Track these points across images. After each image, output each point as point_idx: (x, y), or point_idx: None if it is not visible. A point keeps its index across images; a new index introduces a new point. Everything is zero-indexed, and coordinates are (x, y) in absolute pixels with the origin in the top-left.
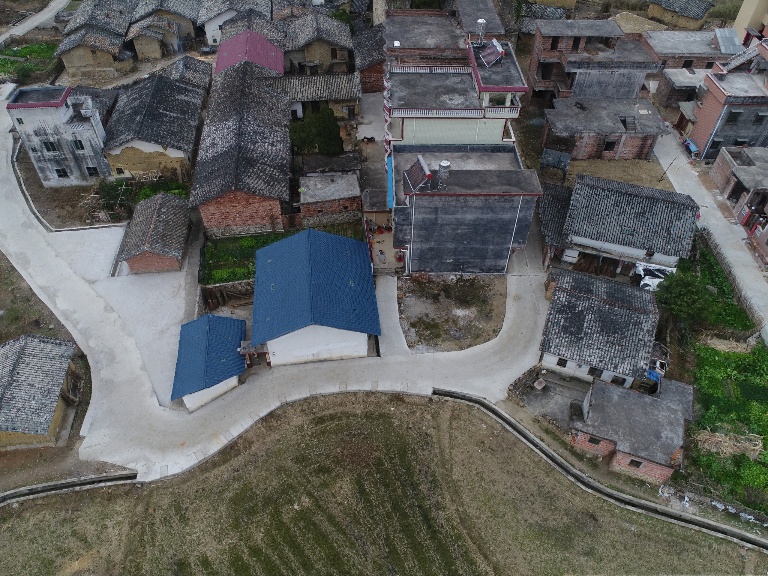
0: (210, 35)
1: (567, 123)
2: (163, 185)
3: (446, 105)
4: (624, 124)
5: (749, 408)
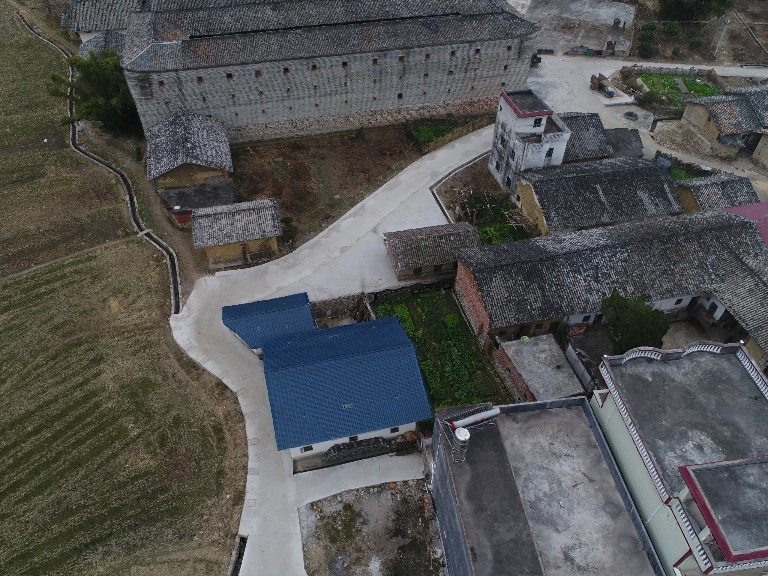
0: None
1: None
2: (521, 235)
3: (675, 440)
4: None
5: None
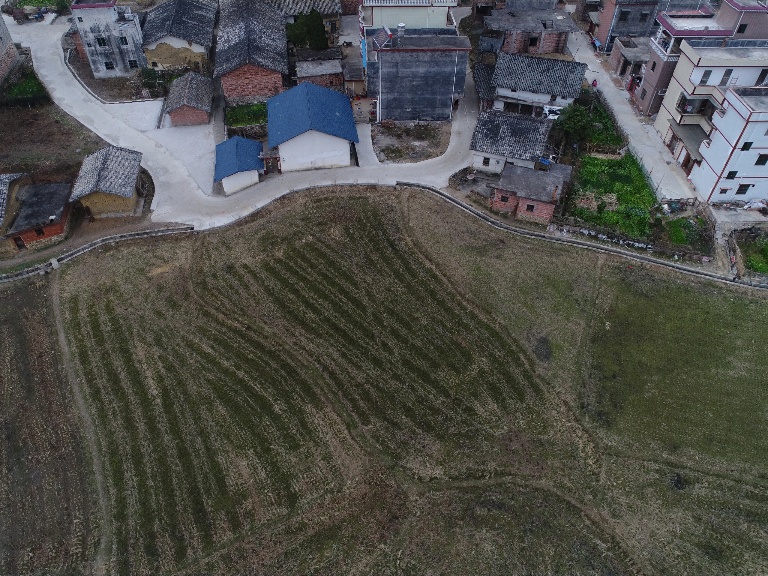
0: None
1: (500, 24)
2: None
3: None
4: (545, 26)
5: (613, 185)
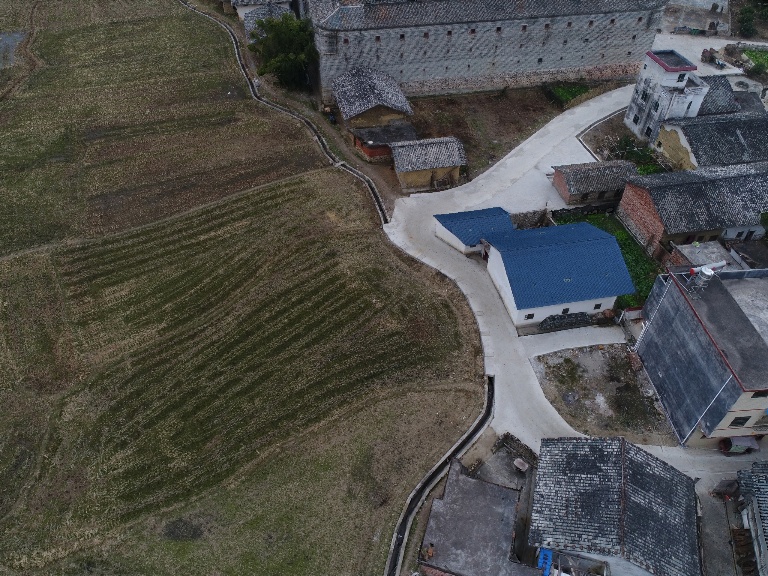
0: None
1: None
2: None
3: None
4: None
5: None
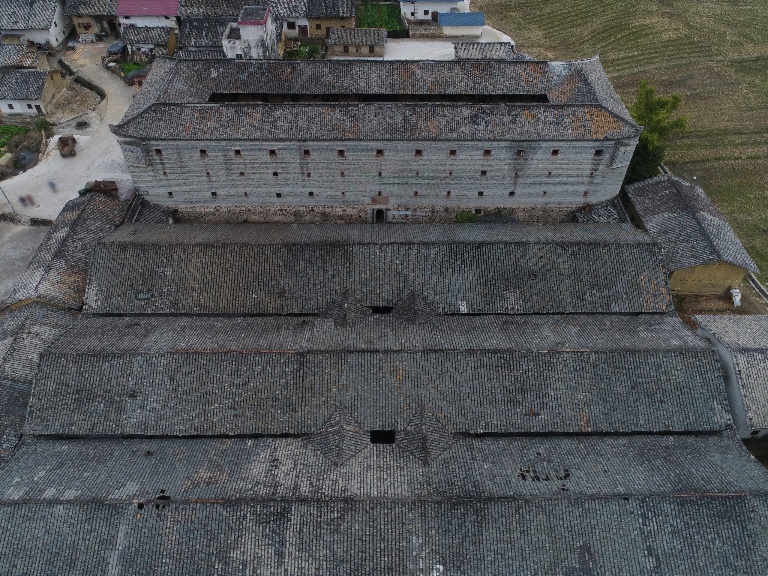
0: (53, 36)
1: None
2: None
3: None
4: None
5: None
